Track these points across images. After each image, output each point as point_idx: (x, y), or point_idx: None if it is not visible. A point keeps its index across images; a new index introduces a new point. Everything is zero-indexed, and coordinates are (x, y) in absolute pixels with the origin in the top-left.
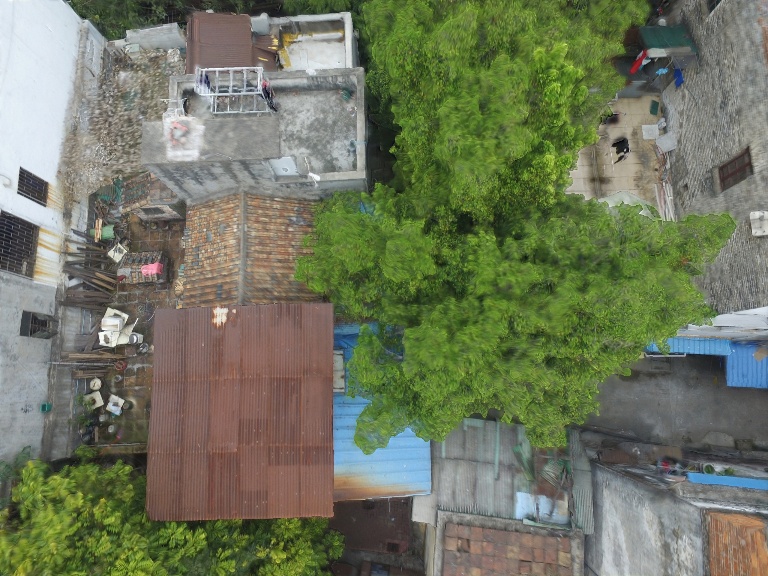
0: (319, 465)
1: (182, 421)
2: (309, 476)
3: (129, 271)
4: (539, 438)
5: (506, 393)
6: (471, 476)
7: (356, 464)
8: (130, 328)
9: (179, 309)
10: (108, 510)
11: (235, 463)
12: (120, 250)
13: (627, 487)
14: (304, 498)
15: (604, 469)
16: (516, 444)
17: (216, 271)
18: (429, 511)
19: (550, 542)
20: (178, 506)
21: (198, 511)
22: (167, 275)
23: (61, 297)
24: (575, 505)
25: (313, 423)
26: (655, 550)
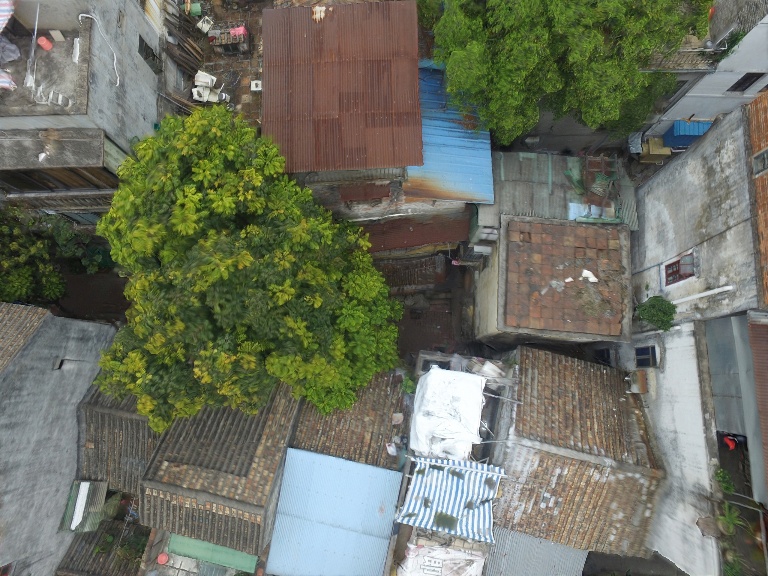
0: (409, 127)
1: (290, 95)
2: (401, 135)
3: (219, 32)
4: (596, 107)
5: (575, 29)
6: (528, 192)
7: (429, 172)
8: (218, 90)
9: (283, 8)
10: (244, 124)
11: (337, 126)
12: (208, 21)
13: (669, 169)
14: (397, 153)
15: (645, 182)
16: (566, 169)
17: (305, 3)
18: (493, 217)
19: (601, 232)
20: (290, 161)
21: (307, 164)
22: (249, 46)
23: (163, 45)
24: (621, 211)
25: (403, 94)
26: (699, 185)
